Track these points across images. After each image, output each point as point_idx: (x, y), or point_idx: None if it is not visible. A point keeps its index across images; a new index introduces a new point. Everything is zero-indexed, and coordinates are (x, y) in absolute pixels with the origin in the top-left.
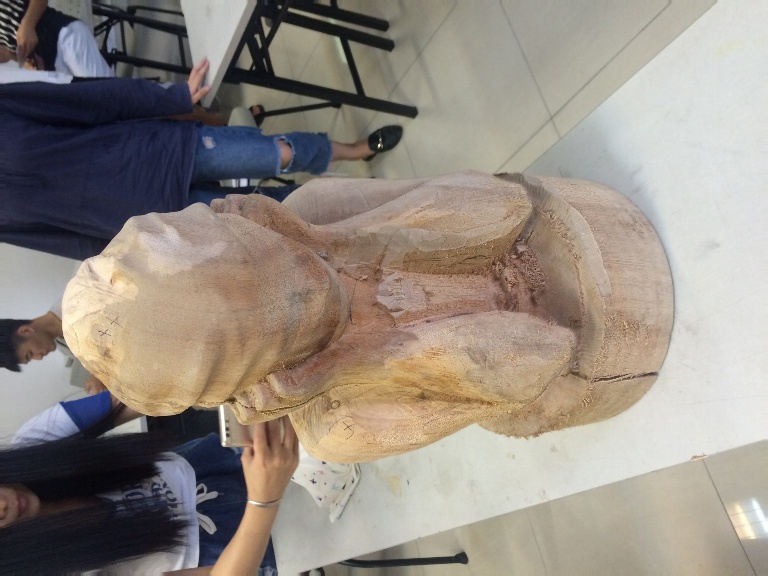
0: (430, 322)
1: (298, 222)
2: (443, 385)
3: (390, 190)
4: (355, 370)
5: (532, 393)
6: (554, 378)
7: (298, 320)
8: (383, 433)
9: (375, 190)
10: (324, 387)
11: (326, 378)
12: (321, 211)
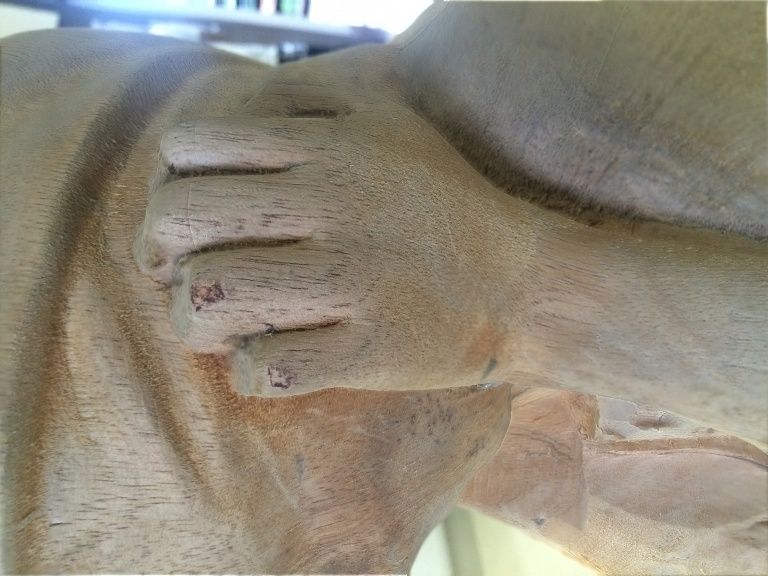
0: (669, 454)
1: (444, 387)
2: None
3: None
4: None
5: None
6: None
7: None
8: None
9: None
10: None
11: None
12: (679, 108)
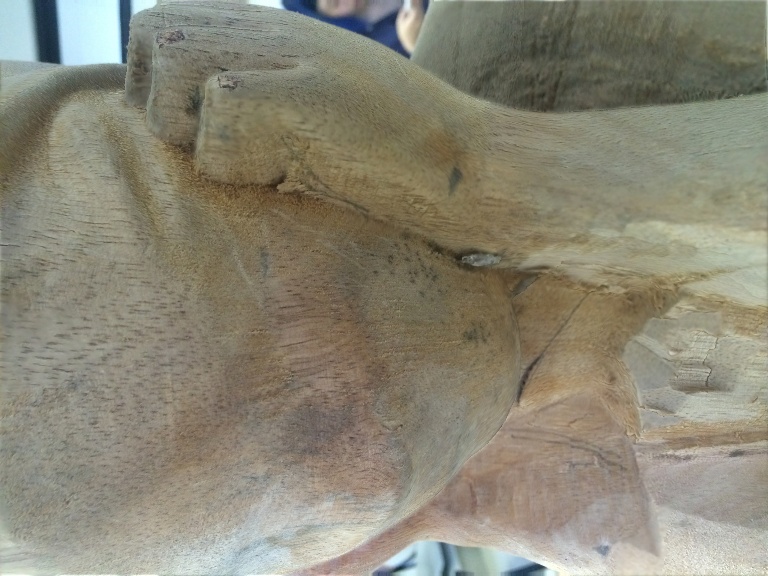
0: (742, 455)
1: (407, 180)
2: None
3: None
4: None
5: None
6: None
7: (266, 569)
8: None
9: None
10: None
11: None
12: None
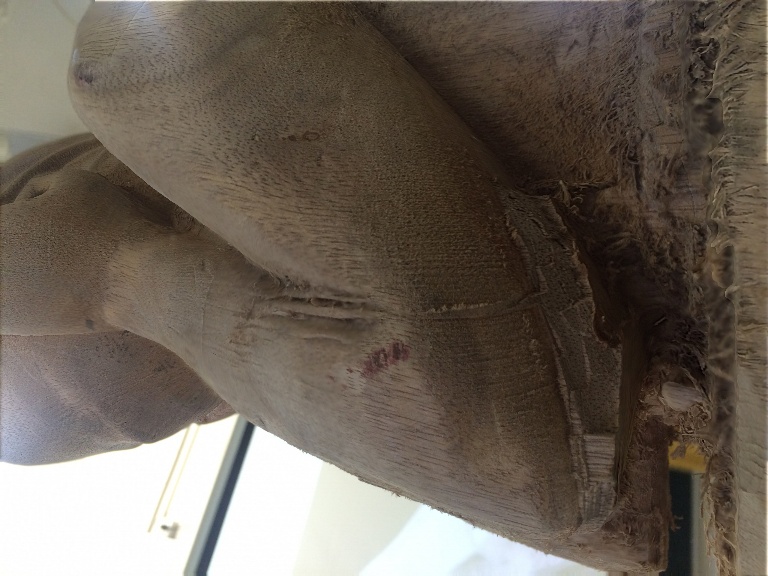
0: None
1: None
2: None
3: (220, 232)
4: None
5: None
6: None
7: None
8: None
9: (190, 211)
10: None
11: None
12: None
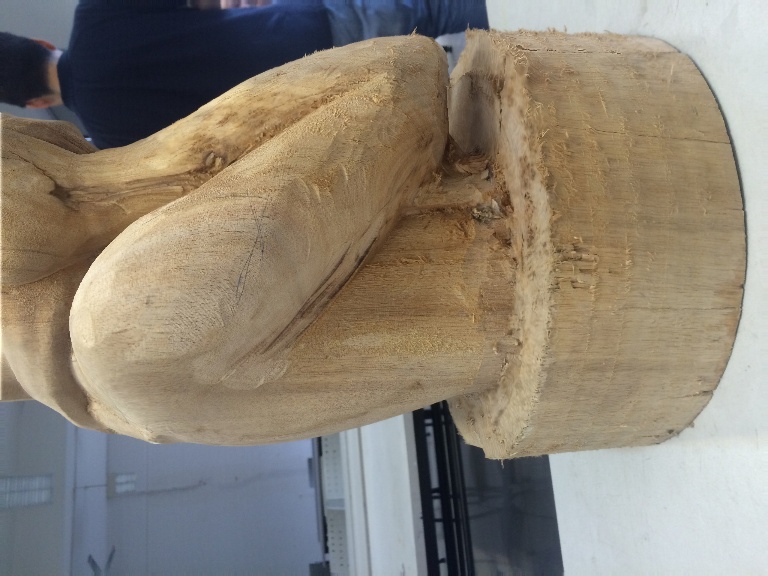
0: None
1: None
2: (234, 111)
3: None
4: (104, 157)
5: (377, 55)
6: (419, 53)
7: (6, 116)
8: (169, 205)
9: None
10: (41, 158)
11: (40, 143)
12: None
